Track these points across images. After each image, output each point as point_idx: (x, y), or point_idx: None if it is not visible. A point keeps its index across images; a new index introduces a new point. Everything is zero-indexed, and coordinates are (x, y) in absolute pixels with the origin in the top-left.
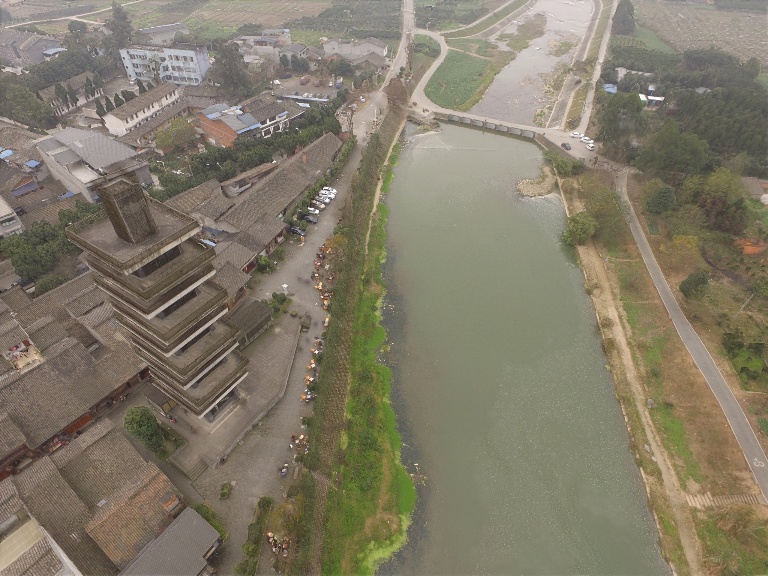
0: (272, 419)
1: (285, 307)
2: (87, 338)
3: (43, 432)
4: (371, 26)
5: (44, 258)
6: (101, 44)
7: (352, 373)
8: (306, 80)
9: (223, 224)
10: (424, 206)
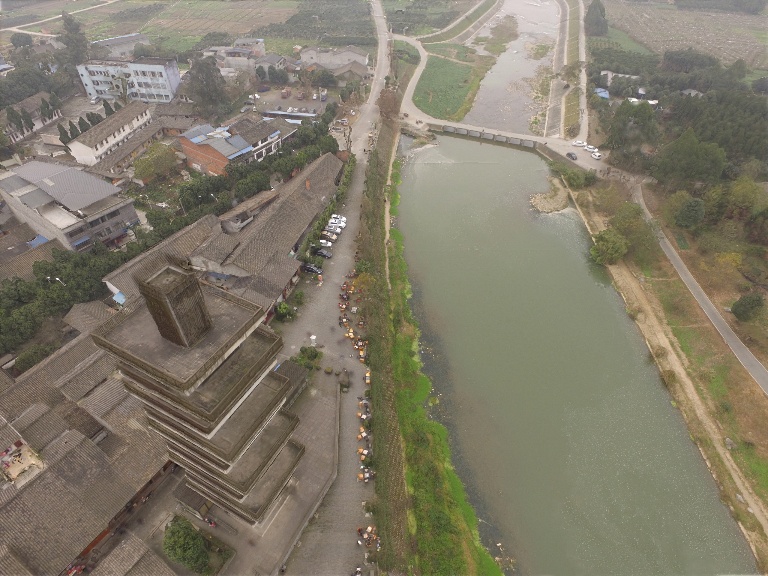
0: (329, 508)
1: (316, 362)
2: (91, 425)
3: (54, 563)
4: (344, 32)
5: (23, 325)
6: (53, 60)
7: (404, 435)
8: (287, 93)
9: (231, 268)
10: (439, 229)
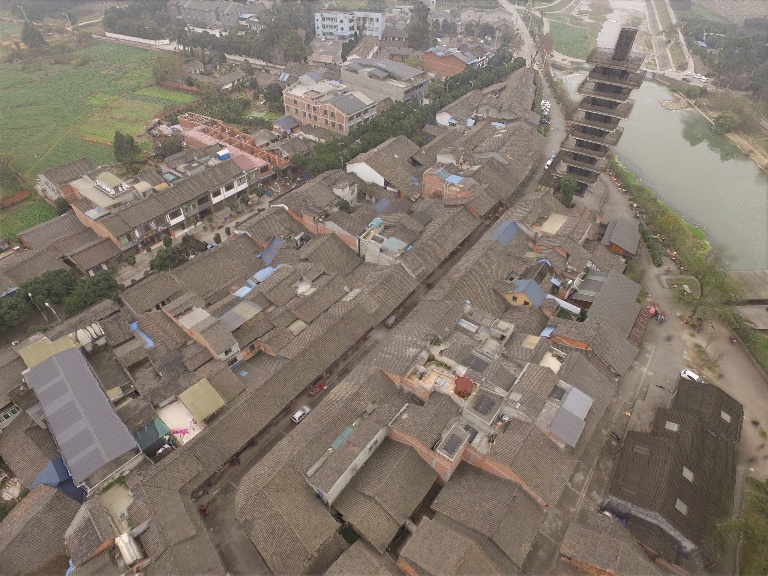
0: (610, 200)
1: None
2: None
3: None
4: (474, 3)
5: (409, 128)
6: None
7: None
8: (461, 38)
9: (505, 113)
10: None
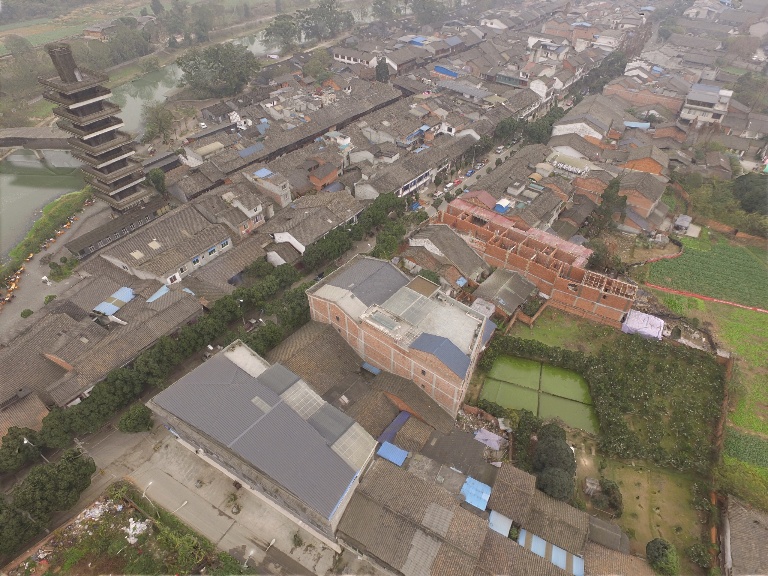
0: None
1: None
2: None
3: None
4: None
5: None
6: None
7: None
8: None
9: None
10: None
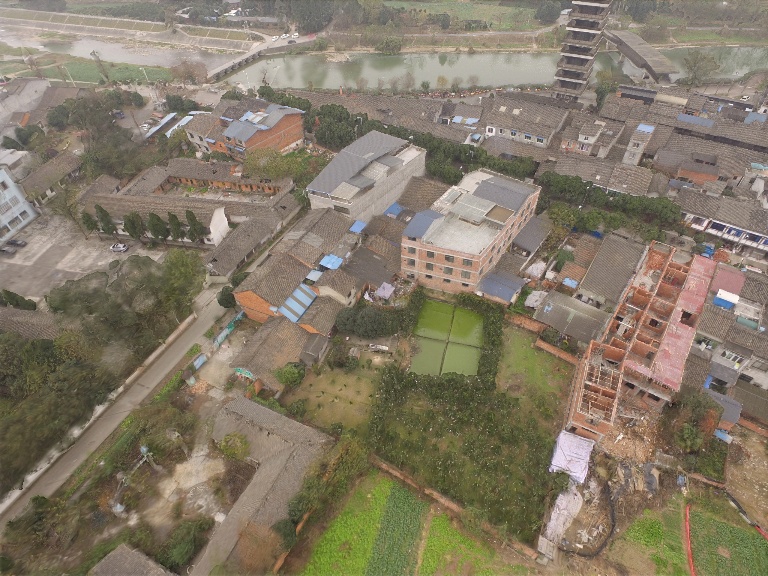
0: None
1: None
2: None
3: None
4: None
5: None
6: None
7: None
8: None
9: None
10: None
